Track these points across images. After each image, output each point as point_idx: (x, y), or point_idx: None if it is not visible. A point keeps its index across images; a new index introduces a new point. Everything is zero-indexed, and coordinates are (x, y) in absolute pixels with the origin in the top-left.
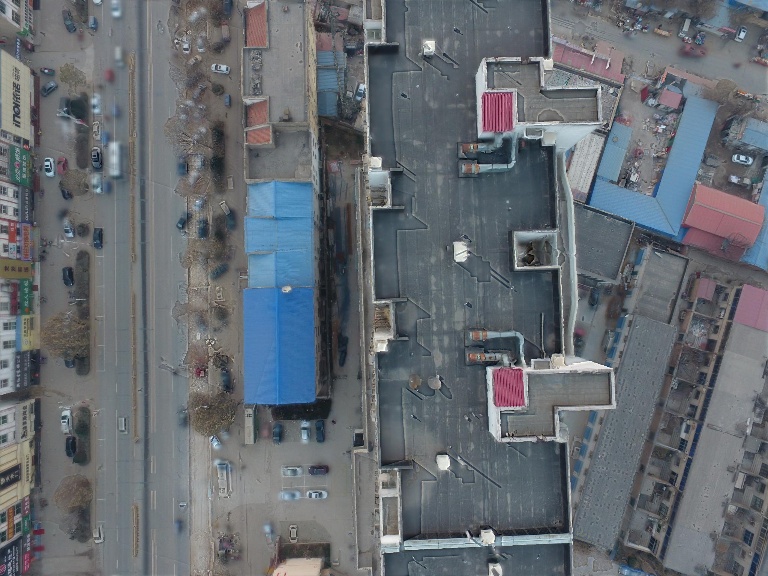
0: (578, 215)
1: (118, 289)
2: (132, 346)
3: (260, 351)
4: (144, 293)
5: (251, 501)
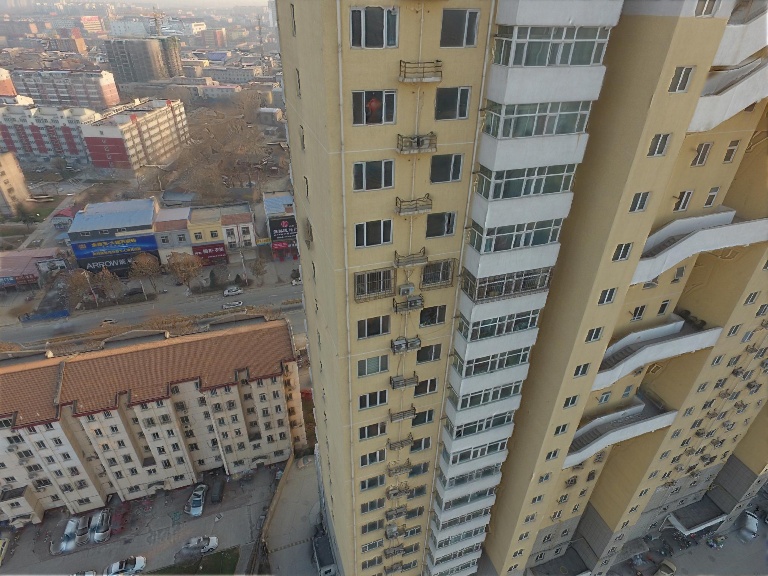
0: None
1: None
2: None
3: None
4: None
5: None
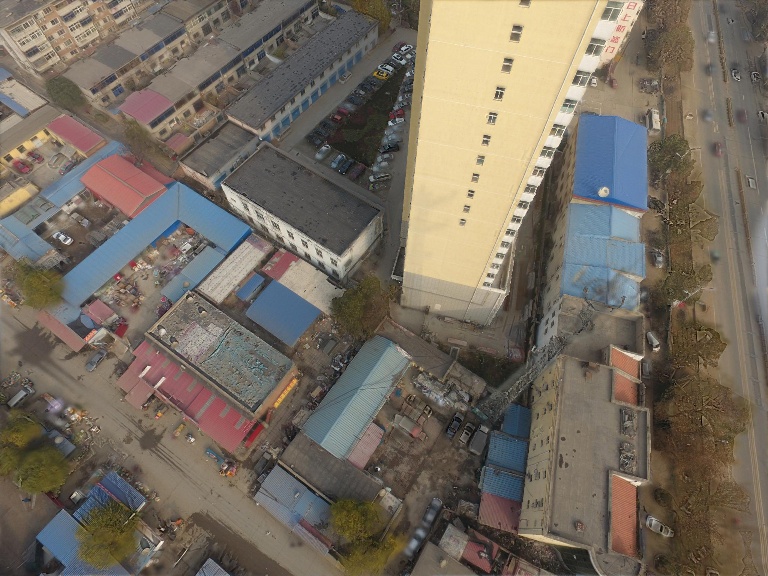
0: (274, 205)
1: None
2: (751, 238)
3: (632, 157)
4: (743, 283)
5: (629, 108)
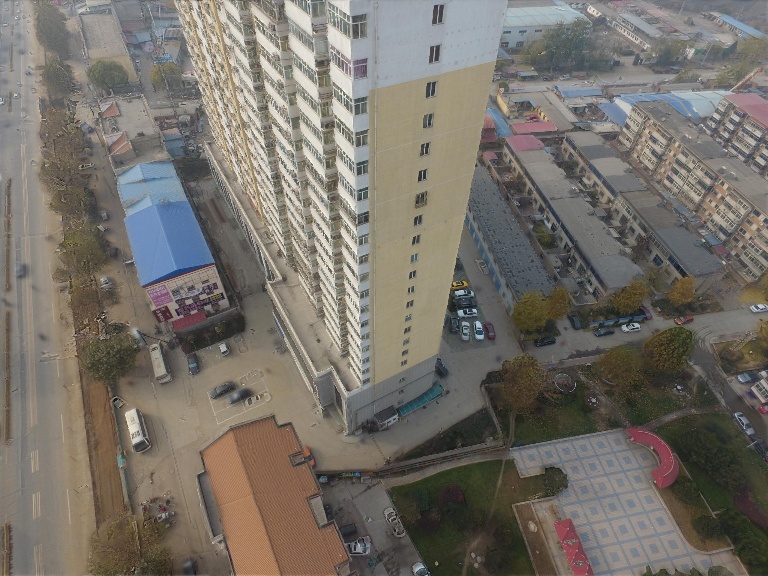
0: None
1: None
2: (5, 351)
3: (149, 245)
4: (20, 308)
5: (178, 445)
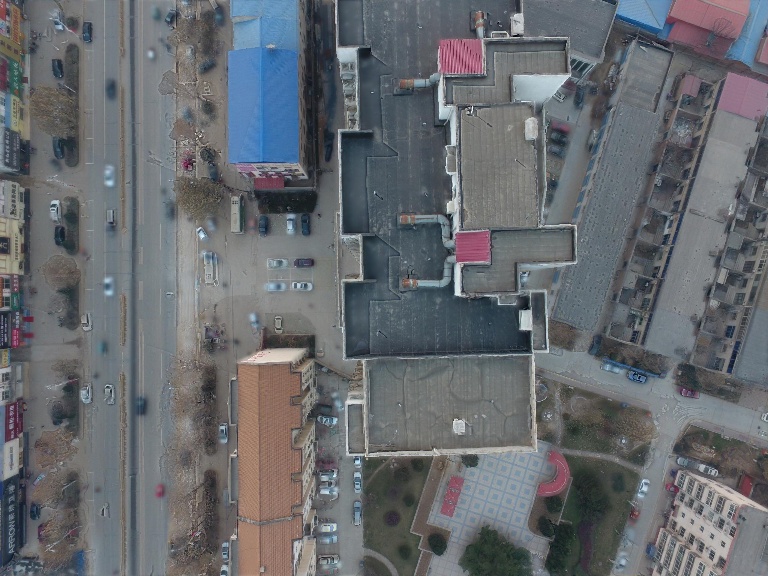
0: None
1: (107, 83)
2: (120, 138)
3: (244, 110)
4: (133, 87)
5: (237, 293)
